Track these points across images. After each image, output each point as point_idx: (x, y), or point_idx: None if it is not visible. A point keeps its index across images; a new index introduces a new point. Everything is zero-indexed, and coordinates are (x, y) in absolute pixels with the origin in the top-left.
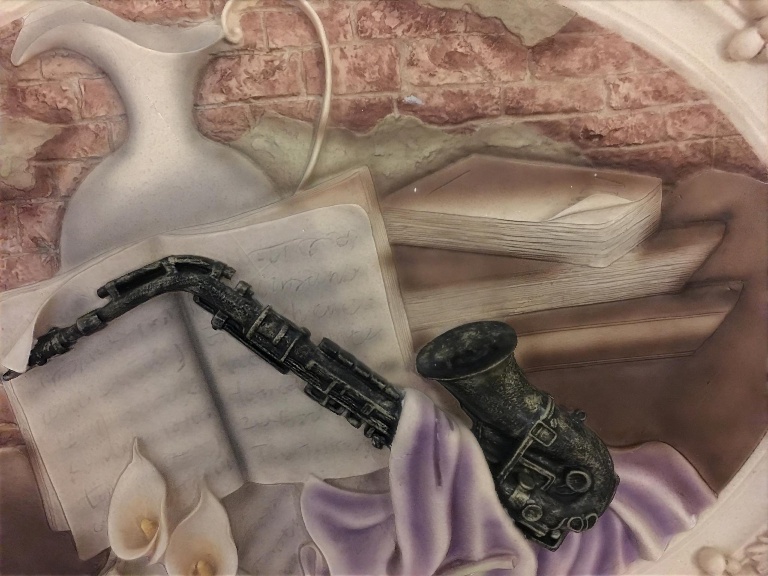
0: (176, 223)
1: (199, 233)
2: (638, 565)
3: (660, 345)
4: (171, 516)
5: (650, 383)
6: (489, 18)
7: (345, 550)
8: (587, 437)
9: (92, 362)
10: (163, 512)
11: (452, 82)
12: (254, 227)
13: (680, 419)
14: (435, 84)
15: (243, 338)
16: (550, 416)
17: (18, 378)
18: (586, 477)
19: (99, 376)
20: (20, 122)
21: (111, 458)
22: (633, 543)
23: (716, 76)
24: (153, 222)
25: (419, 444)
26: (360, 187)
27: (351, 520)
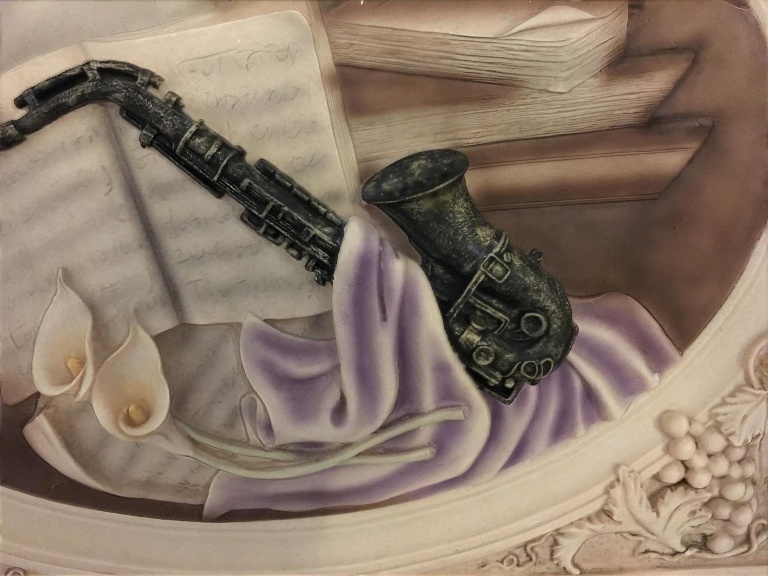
0: (101, 30)
1: (125, 39)
2: (598, 427)
3: (624, 185)
4: (98, 351)
5: (613, 228)
6: None
7: (288, 400)
8: (543, 277)
9: (12, 184)
10: (88, 343)
11: None
12: (184, 33)
13: (644, 269)
14: None
15: (174, 157)
16: (503, 249)
17: None
18: (541, 319)
19: (20, 200)
20: None
21: (35, 292)
22: (593, 403)
23: None
24: (75, 28)
25: (362, 272)
26: None
27: (294, 367)
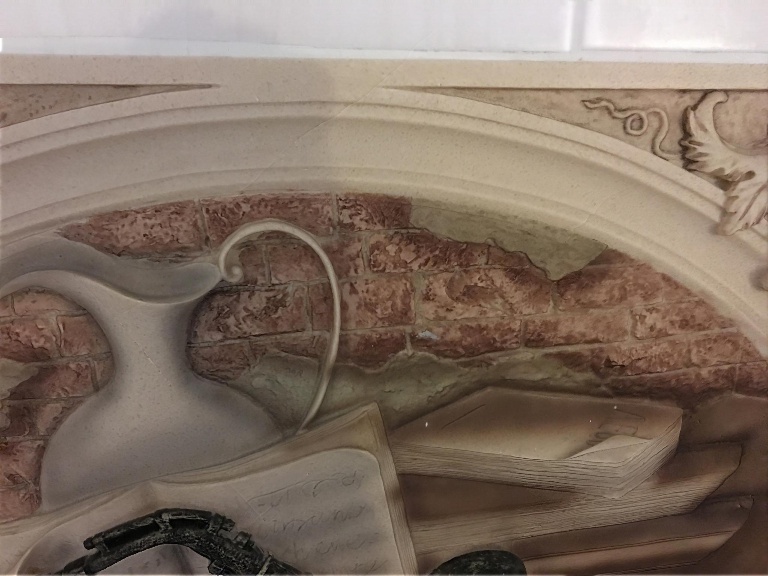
0: (169, 467)
1: (194, 481)
2: None
3: (667, 559)
4: None
5: None
6: (513, 252)
7: None
8: None
9: None
10: None
11: (470, 316)
12: (255, 476)
13: None
14: (452, 319)
15: None
16: None
17: None
18: None
19: None
20: None
21: None
22: None
23: (746, 305)
24: (143, 467)
25: None
26: (368, 426)
27: None
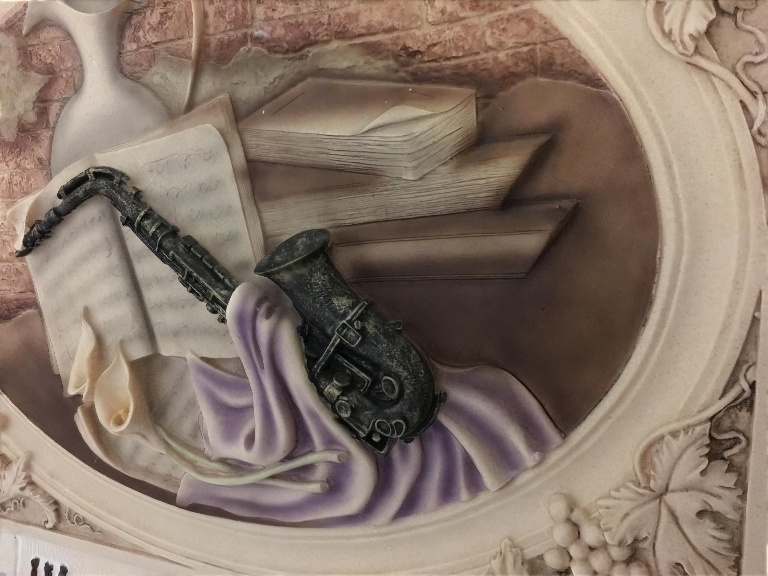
0: (105, 144)
1: (114, 150)
2: (485, 496)
3: (486, 264)
4: (97, 367)
5: (483, 304)
6: None
7: (222, 422)
8: (397, 345)
9: (63, 248)
10: (87, 361)
11: (290, 14)
12: (144, 144)
13: (519, 346)
14: (277, 18)
15: None
16: (355, 318)
17: (31, 258)
18: (394, 383)
19: (66, 259)
20: (28, 75)
21: (76, 322)
22: (478, 471)
23: None
24: (92, 143)
25: (241, 328)
26: (221, 111)
27: (226, 397)
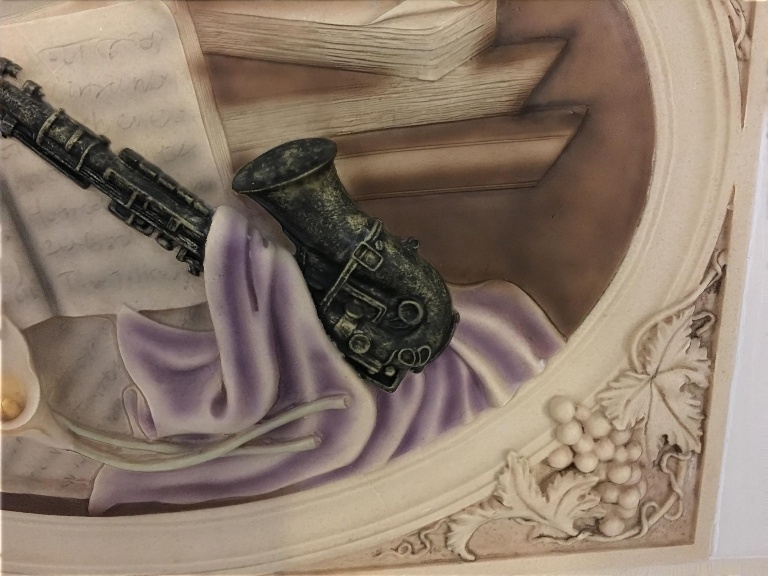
0: None
1: None
2: (487, 414)
3: (500, 173)
4: None
5: (492, 216)
6: None
7: (169, 391)
8: (419, 265)
9: None
10: None
11: None
12: (42, 20)
13: (526, 256)
14: None
15: (36, 147)
16: (375, 238)
17: None
18: (417, 307)
19: None
20: None
21: None
22: (481, 391)
23: None
24: None
25: (229, 262)
26: None
27: (174, 359)
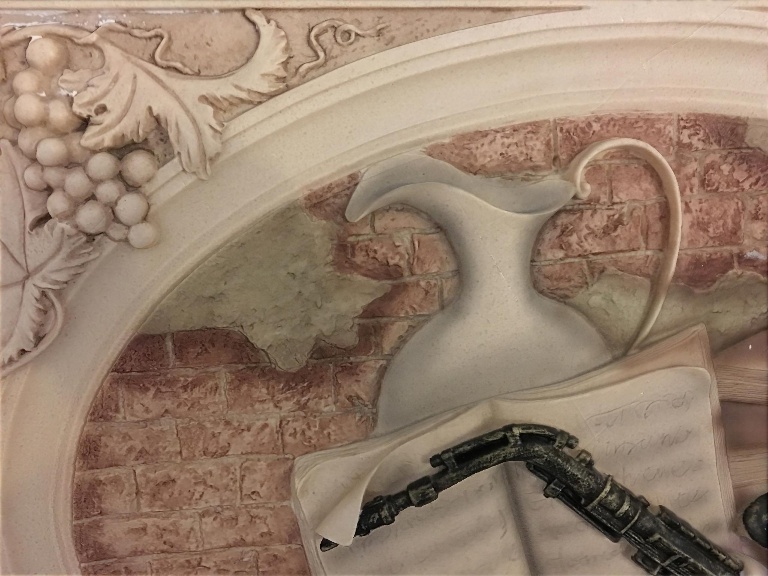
0: (509, 386)
1: (537, 398)
2: None
3: None
4: None
5: None
6: None
7: None
8: None
9: (409, 528)
10: None
11: None
12: (597, 393)
13: None
14: None
15: (577, 507)
16: None
17: None
18: None
19: (416, 543)
20: (349, 279)
21: None
22: None
23: None
24: (486, 385)
25: None
26: (698, 346)
27: None
